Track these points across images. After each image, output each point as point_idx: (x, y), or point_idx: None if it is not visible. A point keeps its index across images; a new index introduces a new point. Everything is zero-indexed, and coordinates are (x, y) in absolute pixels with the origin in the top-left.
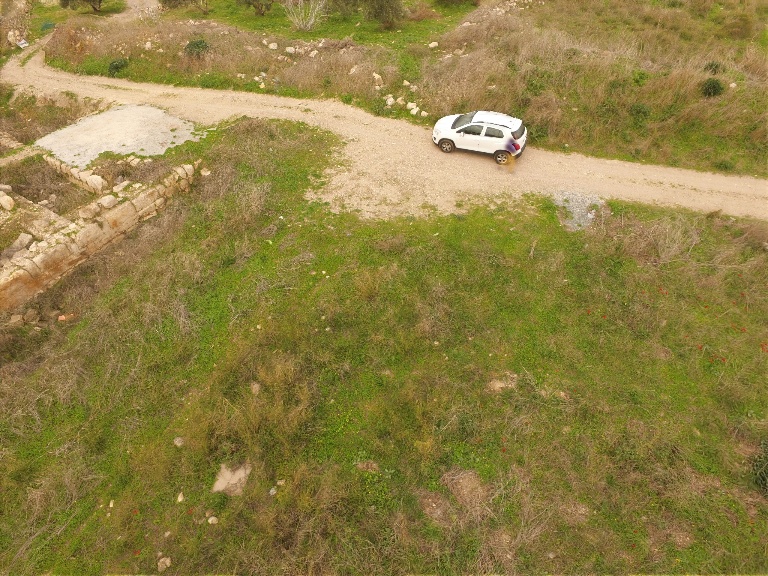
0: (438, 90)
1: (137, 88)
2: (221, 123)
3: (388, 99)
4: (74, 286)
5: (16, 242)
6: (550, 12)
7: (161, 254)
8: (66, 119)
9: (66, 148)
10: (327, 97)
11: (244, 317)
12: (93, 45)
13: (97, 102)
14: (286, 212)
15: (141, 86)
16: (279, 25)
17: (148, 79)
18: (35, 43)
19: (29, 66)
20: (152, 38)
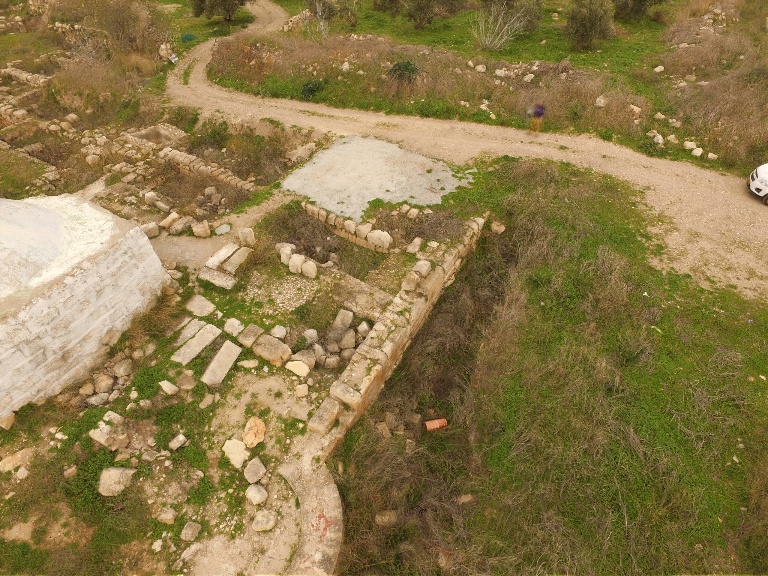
0: (714, 127)
1: (343, 115)
2: (477, 163)
3: (659, 136)
4: (427, 381)
5: (337, 321)
6: (757, 31)
7: (531, 344)
8: (276, 151)
9: (323, 193)
10: (580, 132)
11: (709, 444)
12: (273, 63)
13: (308, 132)
14: (648, 287)
15: (346, 113)
16: (451, 41)
17: (350, 104)
18: (184, 57)
19: (194, 84)
20: (348, 58)
